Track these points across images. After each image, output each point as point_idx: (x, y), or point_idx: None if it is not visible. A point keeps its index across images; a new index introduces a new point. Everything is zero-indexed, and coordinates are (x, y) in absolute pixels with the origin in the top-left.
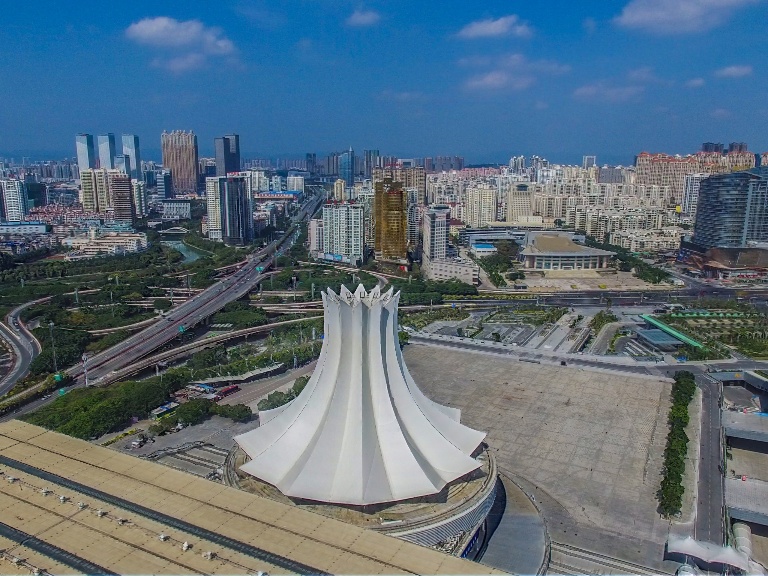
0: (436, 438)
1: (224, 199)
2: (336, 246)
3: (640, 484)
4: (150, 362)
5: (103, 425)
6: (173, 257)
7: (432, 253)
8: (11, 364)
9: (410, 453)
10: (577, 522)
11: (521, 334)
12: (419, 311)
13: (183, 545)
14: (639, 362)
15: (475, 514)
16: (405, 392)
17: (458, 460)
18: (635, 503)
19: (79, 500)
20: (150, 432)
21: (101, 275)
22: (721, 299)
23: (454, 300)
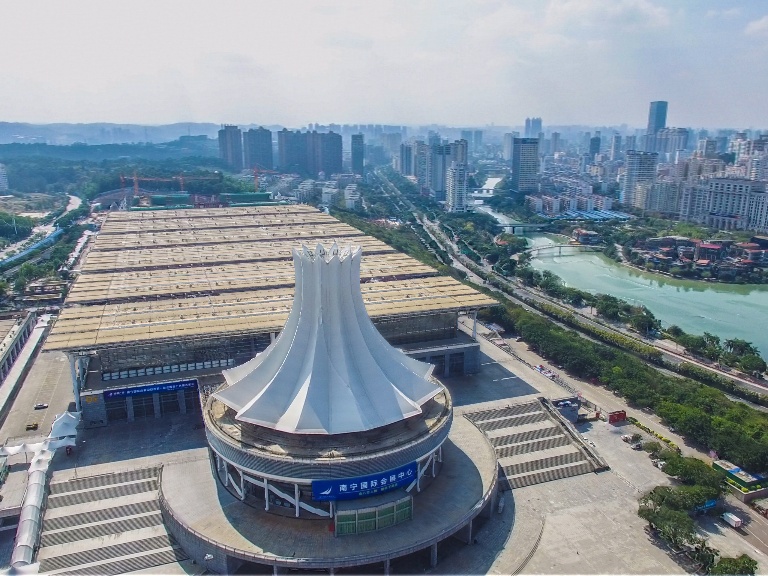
0: None
1: None
2: None
3: None
4: None
5: None
6: None
7: None
8: None
9: None
10: None
11: None
12: None
13: None
14: None
15: None
16: None
17: None
18: None
19: None
20: None
21: None
22: None
23: None
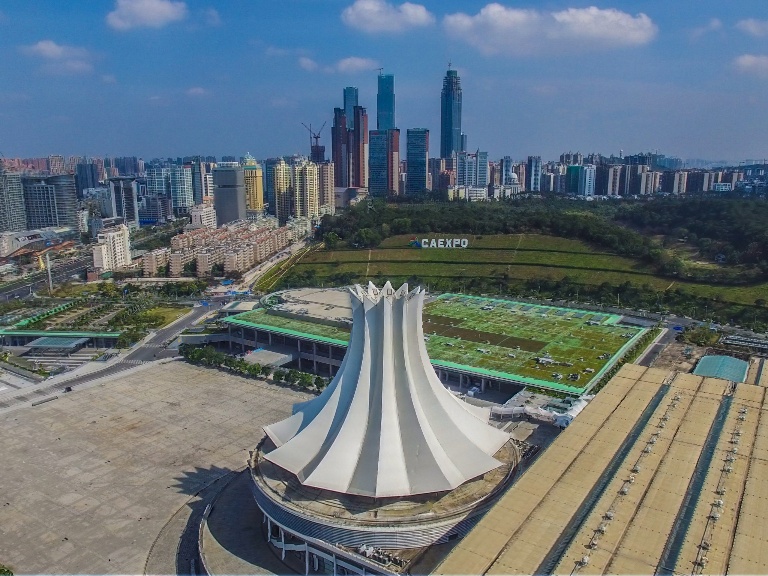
0: None
1: None
2: None
3: None
4: None
5: None
6: None
7: None
8: None
9: None
10: None
11: None
12: None
13: None
14: (108, 362)
15: None
16: None
17: None
18: None
19: (579, 554)
20: None
21: None
22: (2, 302)
23: None
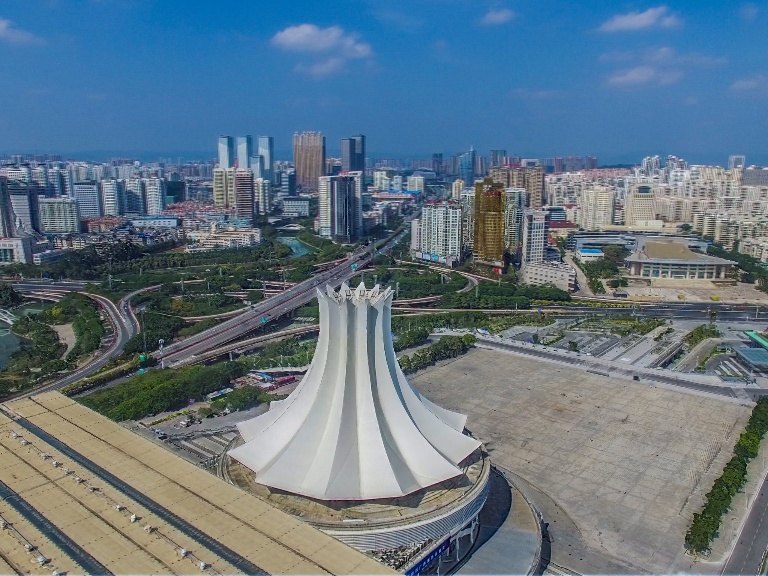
0: (419, 441)
1: (334, 198)
2: (433, 246)
3: (675, 514)
4: (227, 349)
5: (160, 404)
6: (282, 252)
7: (528, 256)
8: (111, 343)
9: (385, 454)
10: (587, 546)
11: (604, 344)
12: (502, 315)
13: (131, 517)
14: (726, 383)
15: (446, 523)
16: (392, 393)
17: (438, 466)
18: (661, 534)
19: (69, 466)
20: (199, 414)
21: (212, 267)
22: None
23: (543, 305)
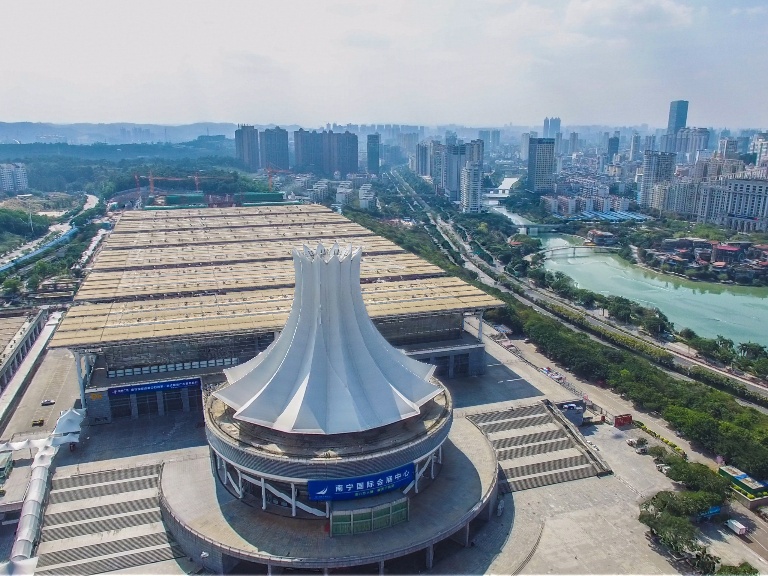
0: None
1: None
2: None
3: None
4: None
5: None
6: None
7: None
8: None
9: None
10: None
11: None
12: None
13: None
14: None
15: None
16: None
17: None
18: None
19: None
20: None
21: None
22: None
23: None
